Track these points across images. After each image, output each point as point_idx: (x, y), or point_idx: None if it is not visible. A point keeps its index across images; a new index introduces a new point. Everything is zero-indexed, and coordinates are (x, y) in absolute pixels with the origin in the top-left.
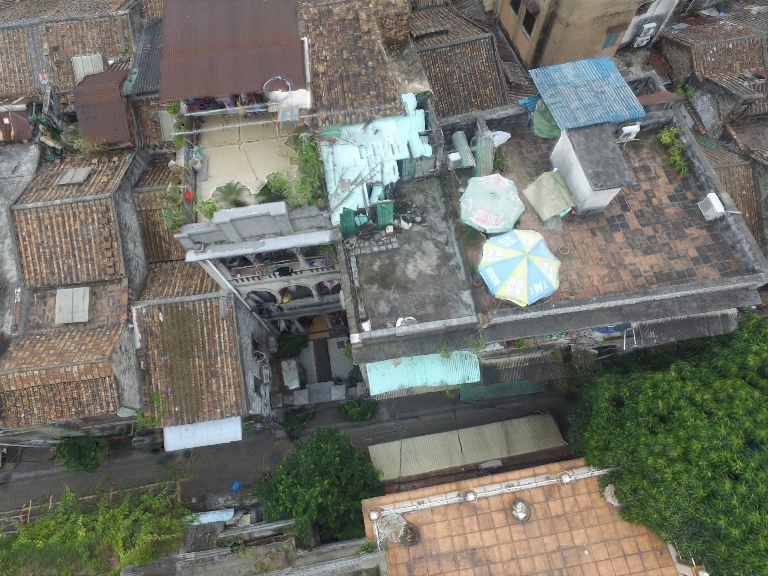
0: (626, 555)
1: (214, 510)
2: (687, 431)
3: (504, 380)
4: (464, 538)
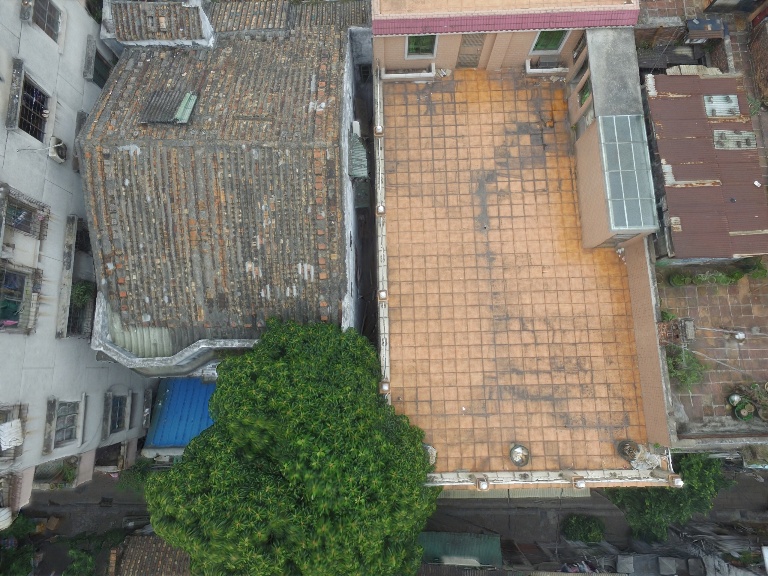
0: (430, 402)
1: (765, 469)
2: (383, 533)
3: (483, 573)
4: (574, 438)
